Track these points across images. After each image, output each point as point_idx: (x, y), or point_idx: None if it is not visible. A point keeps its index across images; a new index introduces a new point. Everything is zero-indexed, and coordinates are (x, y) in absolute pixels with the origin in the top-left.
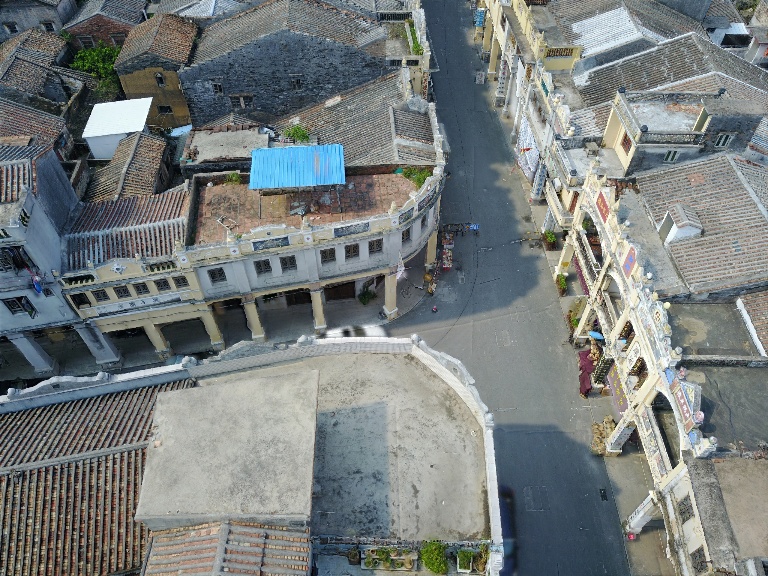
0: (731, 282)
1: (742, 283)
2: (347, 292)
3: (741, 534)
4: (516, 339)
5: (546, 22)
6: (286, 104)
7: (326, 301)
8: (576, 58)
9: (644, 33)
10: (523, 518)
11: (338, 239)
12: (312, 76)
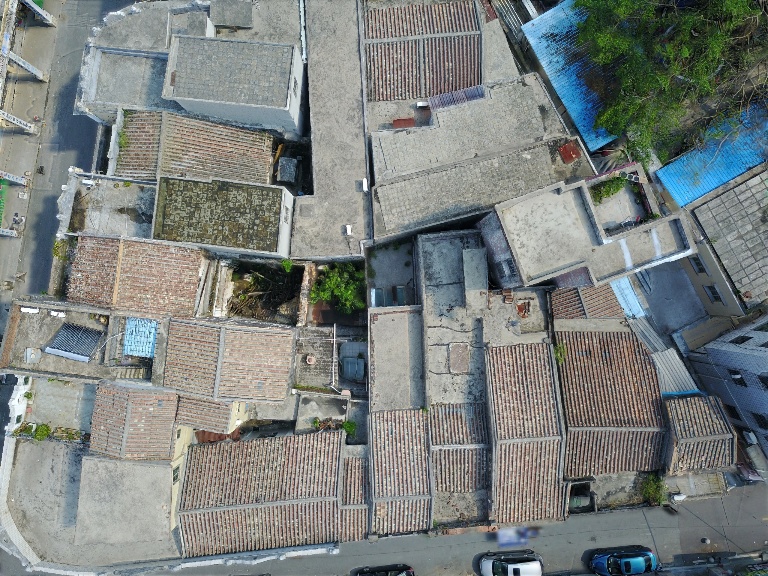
0: None
1: None
2: None
3: None
4: None
5: None
6: None
7: None
8: None
9: None
10: None
11: None
12: None
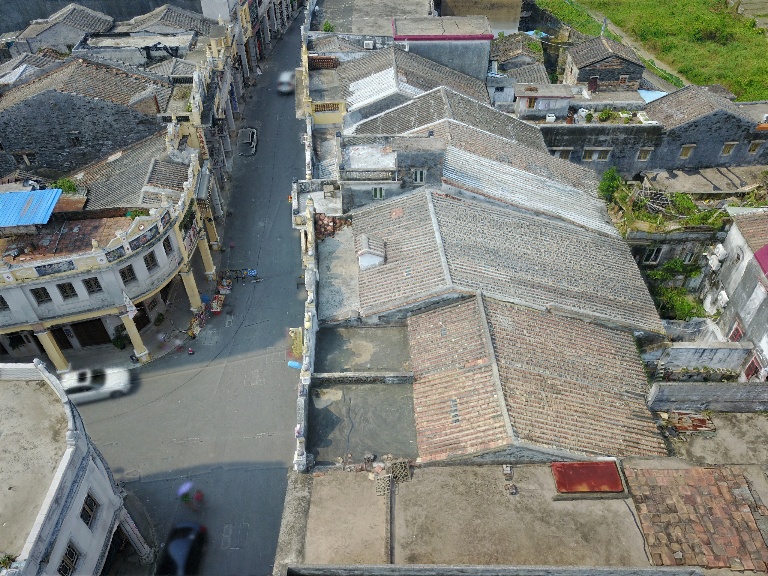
0: (392, 304)
1: (401, 304)
2: (102, 337)
3: (312, 546)
4: (265, 378)
5: (330, 83)
6: (71, 160)
7: (83, 347)
8: (343, 112)
9: (402, 88)
10: (215, 557)
11: (44, 278)
12: (89, 133)
